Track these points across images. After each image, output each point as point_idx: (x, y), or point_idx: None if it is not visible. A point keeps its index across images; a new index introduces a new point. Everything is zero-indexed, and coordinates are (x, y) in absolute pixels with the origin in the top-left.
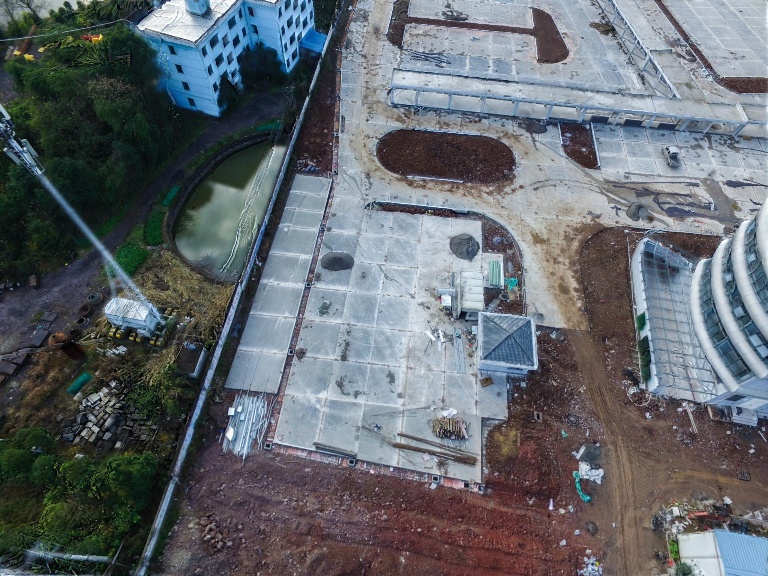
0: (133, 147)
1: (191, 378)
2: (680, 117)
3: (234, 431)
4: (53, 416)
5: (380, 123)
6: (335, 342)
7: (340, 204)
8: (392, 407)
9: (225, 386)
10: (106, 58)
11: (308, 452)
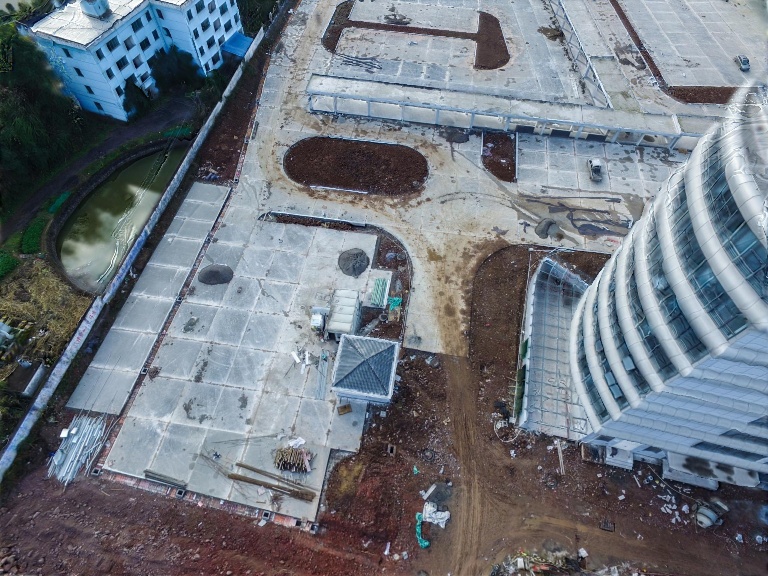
0: (14, 152)
1: (23, 396)
2: (608, 128)
3: (62, 454)
4: None
5: (294, 130)
6: (193, 361)
7: (233, 214)
8: (237, 434)
9: (66, 405)
10: (5, 61)
11: (137, 480)
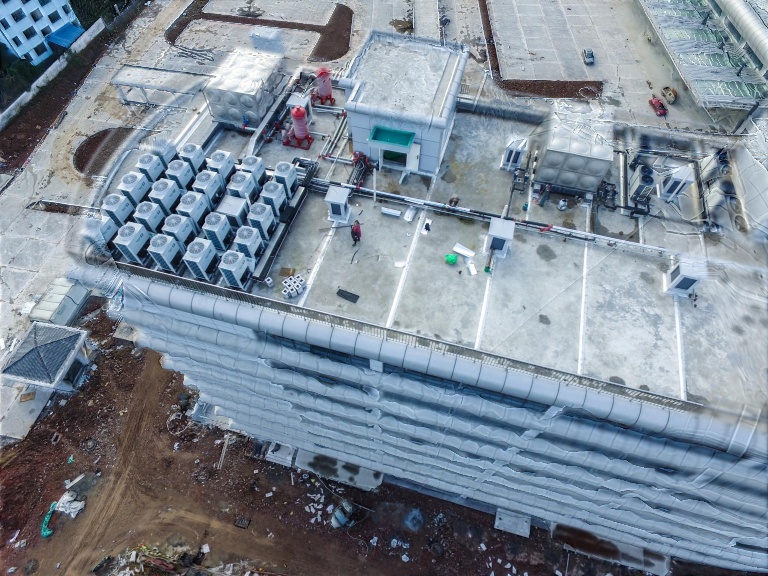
0: None
1: None
2: None
3: None
4: None
5: (100, 120)
6: None
7: (4, 202)
8: None
9: None
10: None
11: None
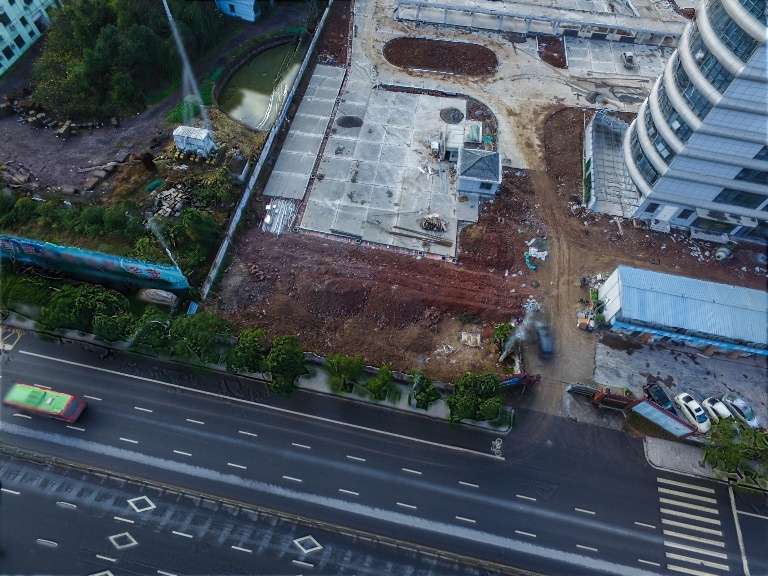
0: (190, 29)
1: (239, 180)
2: (637, 30)
3: (271, 218)
4: (136, 203)
5: (387, 32)
6: (347, 171)
7: (352, 85)
8: (390, 211)
9: (263, 193)
10: None
11: (326, 235)
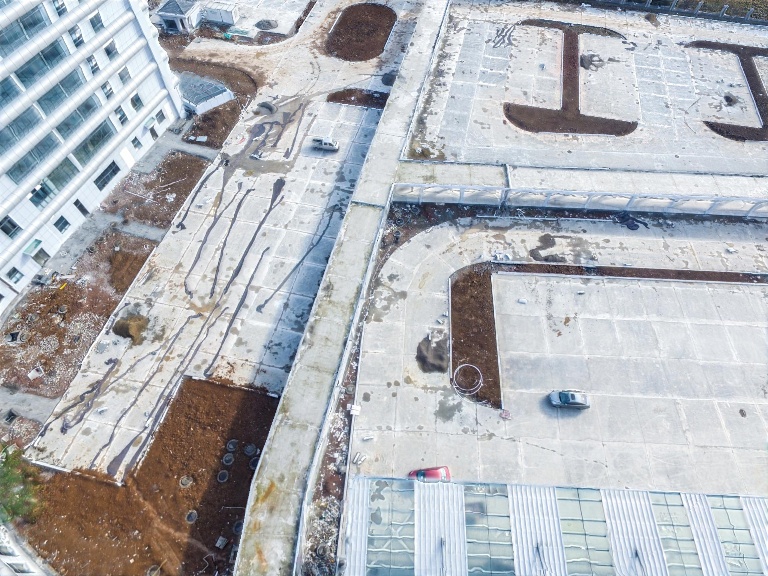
0: None
1: None
2: None
3: None
4: None
5: (404, 6)
6: None
7: None
8: None
9: None
10: None
11: None
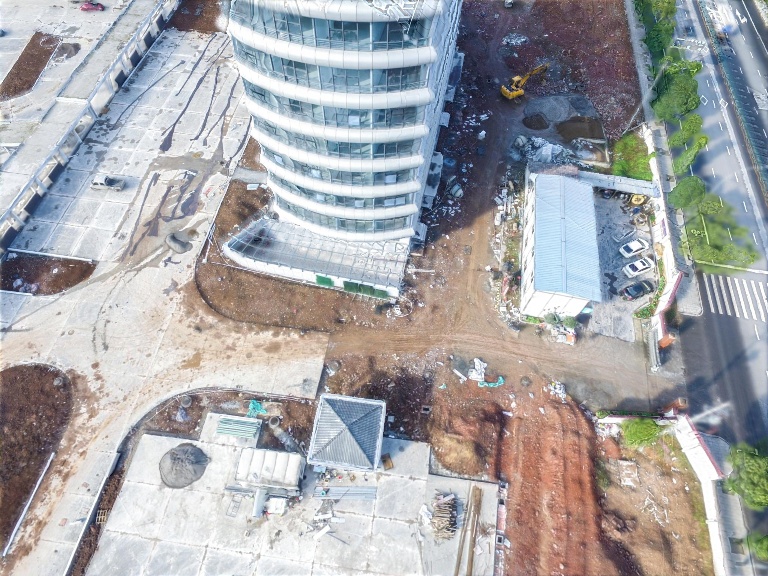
0: None
1: None
2: (51, 155)
3: None
4: None
5: None
6: None
7: None
8: None
9: None
10: None
11: None
